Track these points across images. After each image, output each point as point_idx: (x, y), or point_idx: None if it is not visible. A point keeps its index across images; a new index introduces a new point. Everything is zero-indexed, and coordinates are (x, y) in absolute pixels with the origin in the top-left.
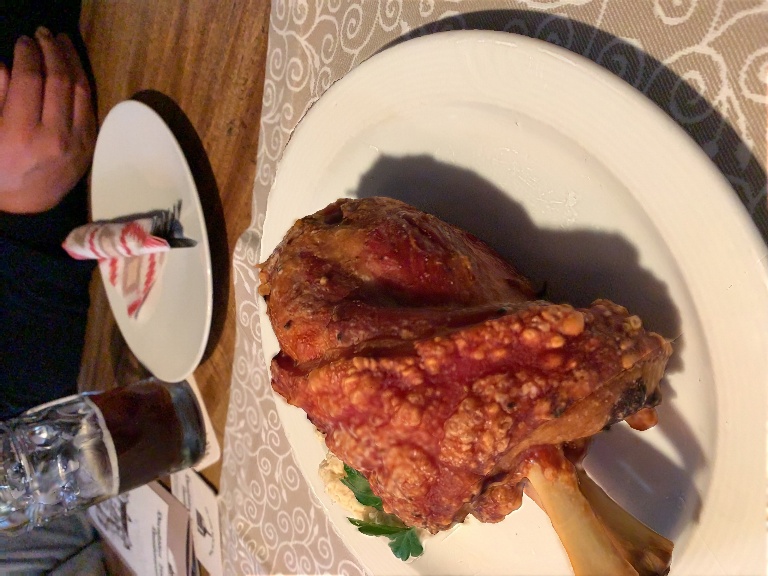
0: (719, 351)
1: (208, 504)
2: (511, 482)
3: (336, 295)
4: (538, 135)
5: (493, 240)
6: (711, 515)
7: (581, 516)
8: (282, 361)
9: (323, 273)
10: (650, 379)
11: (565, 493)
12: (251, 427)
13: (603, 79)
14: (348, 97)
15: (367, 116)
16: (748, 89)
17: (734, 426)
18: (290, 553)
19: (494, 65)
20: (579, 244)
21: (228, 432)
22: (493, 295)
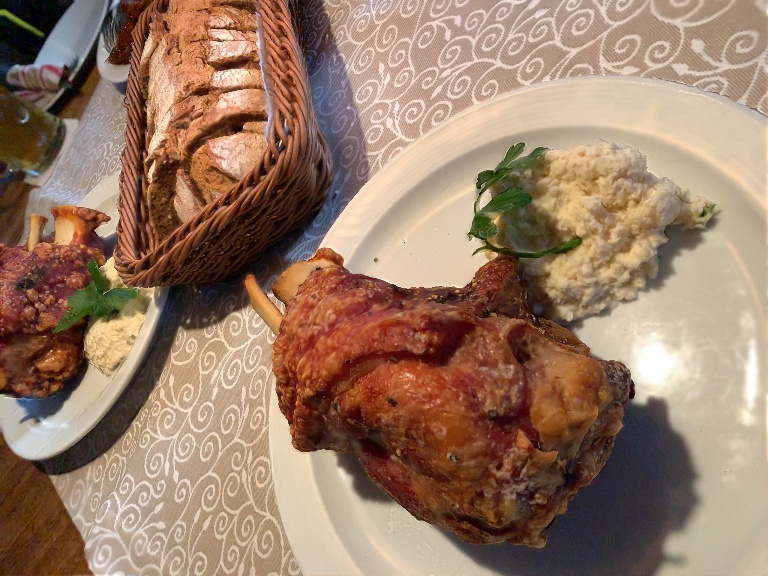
0: None
1: None
2: None
3: None
4: None
5: None
6: None
7: None
8: None
9: (410, 460)
10: None
11: None
12: None
13: None
14: None
15: None
16: None
17: None
18: None
19: None
20: None
21: None
22: None
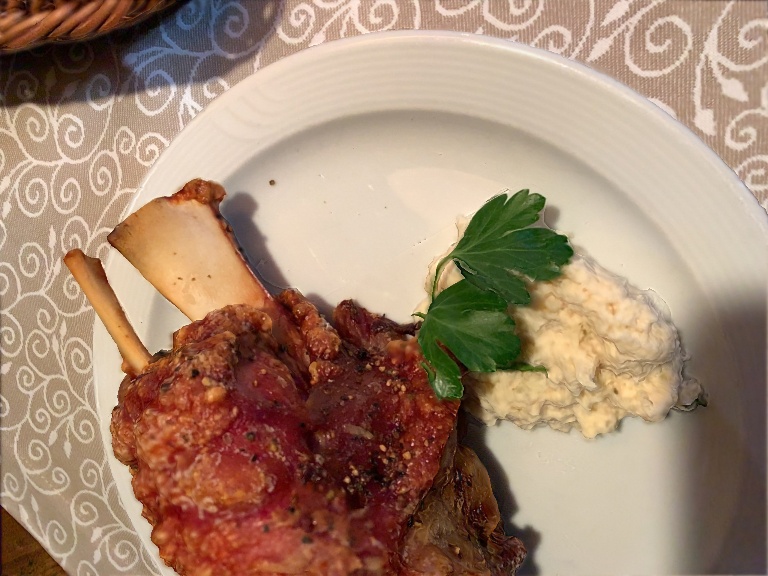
0: None
1: None
2: None
3: None
4: None
5: None
6: None
7: None
8: None
9: None
10: None
11: None
12: None
13: (158, 566)
14: None
15: None
16: None
17: (137, 320)
18: None
19: None
20: None
21: None
22: None
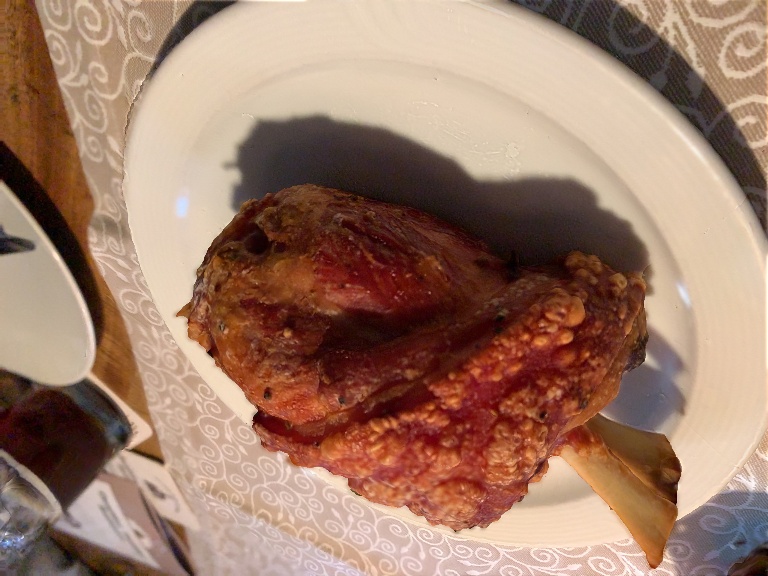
0: (696, 284)
1: (157, 474)
2: None
3: (309, 345)
4: (466, 91)
5: (430, 202)
6: (696, 408)
7: (620, 478)
8: (268, 423)
9: (281, 322)
10: (643, 330)
11: (601, 463)
12: (181, 403)
13: (547, 32)
14: (198, 66)
15: (232, 86)
16: (696, 12)
17: (714, 341)
18: (266, 492)
19: (398, 18)
20: (529, 194)
21: (154, 411)
22: (471, 288)
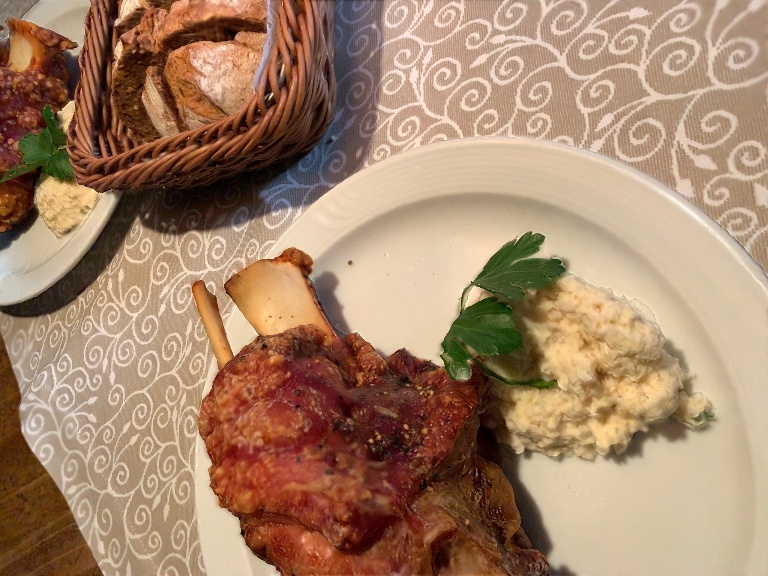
0: None
1: None
2: None
3: None
4: None
5: None
6: None
7: None
8: None
9: None
10: None
11: None
12: None
13: None
14: None
15: None
16: None
17: None
18: None
19: None
20: None
21: None
22: None
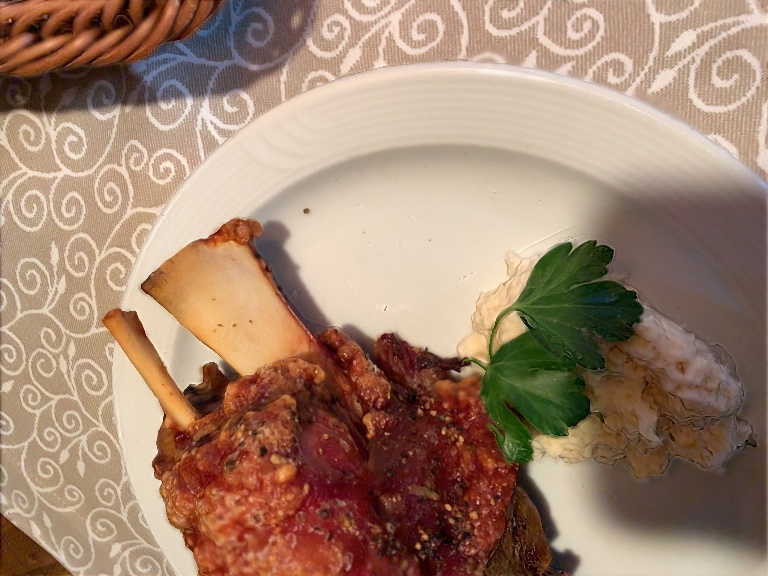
0: None
1: None
2: (211, 419)
3: None
4: None
5: None
6: None
7: None
8: None
9: None
10: None
11: None
12: None
13: None
14: None
15: None
16: None
17: (160, 350)
18: None
19: None
20: None
21: None
22: None
